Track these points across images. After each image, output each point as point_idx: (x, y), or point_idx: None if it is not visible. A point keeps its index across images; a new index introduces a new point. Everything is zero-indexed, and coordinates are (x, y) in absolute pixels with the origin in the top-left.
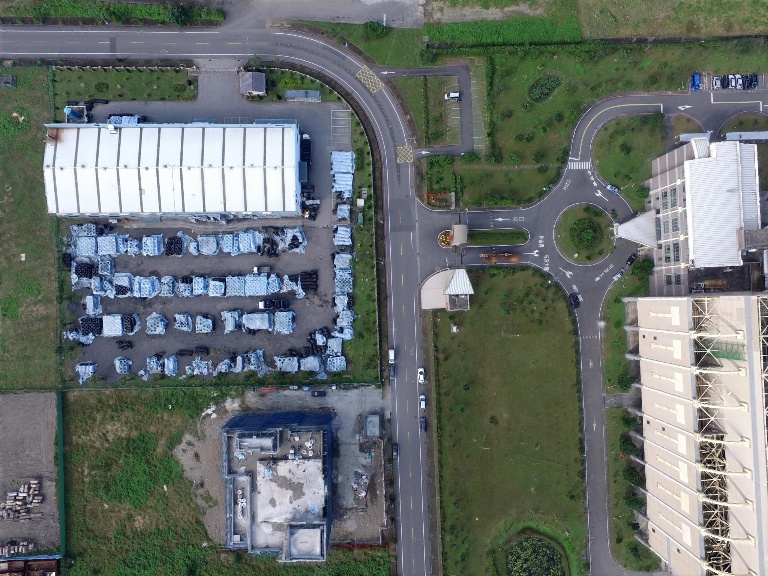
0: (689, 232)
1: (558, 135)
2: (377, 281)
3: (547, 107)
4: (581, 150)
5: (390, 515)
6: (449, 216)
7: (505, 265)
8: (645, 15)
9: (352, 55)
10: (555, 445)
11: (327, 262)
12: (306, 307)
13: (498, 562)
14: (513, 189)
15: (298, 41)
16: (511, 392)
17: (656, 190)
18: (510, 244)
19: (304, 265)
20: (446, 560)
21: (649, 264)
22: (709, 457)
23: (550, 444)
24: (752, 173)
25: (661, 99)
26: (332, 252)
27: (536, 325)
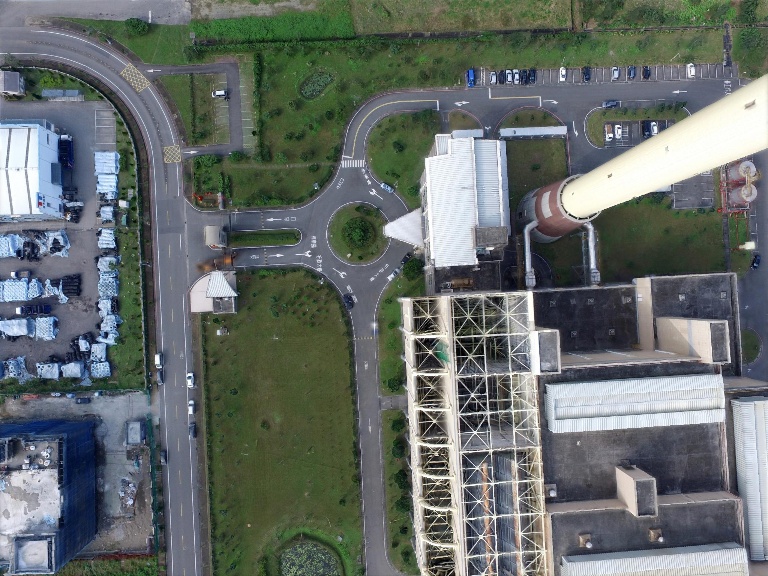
0: (430, 231)
1: (330, 133)
2: (143, 284)
3: (318, 104)
4: (355, 148)
5: (159, 523)
6: (219, 217)
7: (277, 266)
8: (419, 9)
9: (116, 53)
10: (329, 449)
11: (91, 266)
12: (69, 312)
13: (271, 569)
14: (284, 188)
15: (59, 39)
16: (284, 396)
17: (422, 188)
18: (282, 245)
19: (67, 269)
20: (217, 568)
21: (417, 263)
22: (442, 460)
23: (324, 448)
24: (494, 170)
25: (437, 95)
26: (96, 255)
27: (308, 327)
